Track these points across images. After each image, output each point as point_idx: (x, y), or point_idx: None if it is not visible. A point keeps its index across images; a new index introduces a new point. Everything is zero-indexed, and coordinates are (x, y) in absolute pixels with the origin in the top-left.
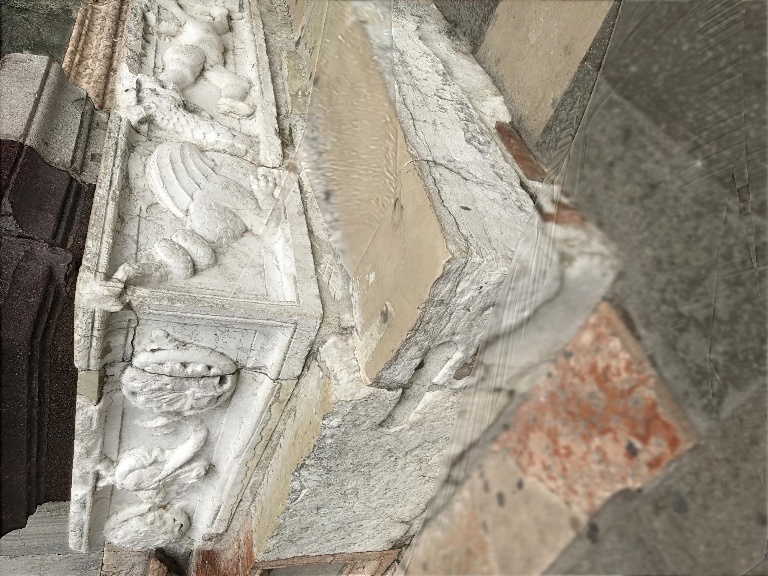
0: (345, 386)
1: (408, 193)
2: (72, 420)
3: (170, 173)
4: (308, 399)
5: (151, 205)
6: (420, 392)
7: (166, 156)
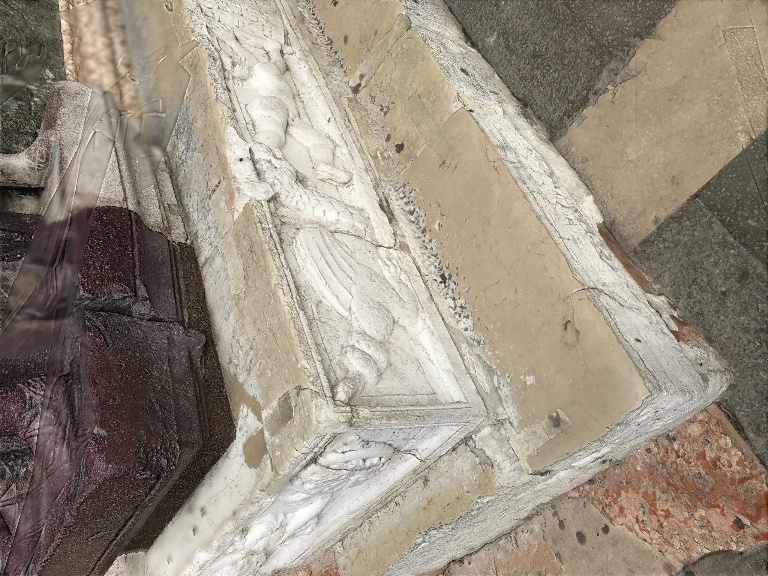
0: (507, 474)
1: (586, 321)
2: (189, 490)
3: (326, 268)
4: (453, 476)
5: (318, 304)
6: (557, 471)
7: (315, 247)
